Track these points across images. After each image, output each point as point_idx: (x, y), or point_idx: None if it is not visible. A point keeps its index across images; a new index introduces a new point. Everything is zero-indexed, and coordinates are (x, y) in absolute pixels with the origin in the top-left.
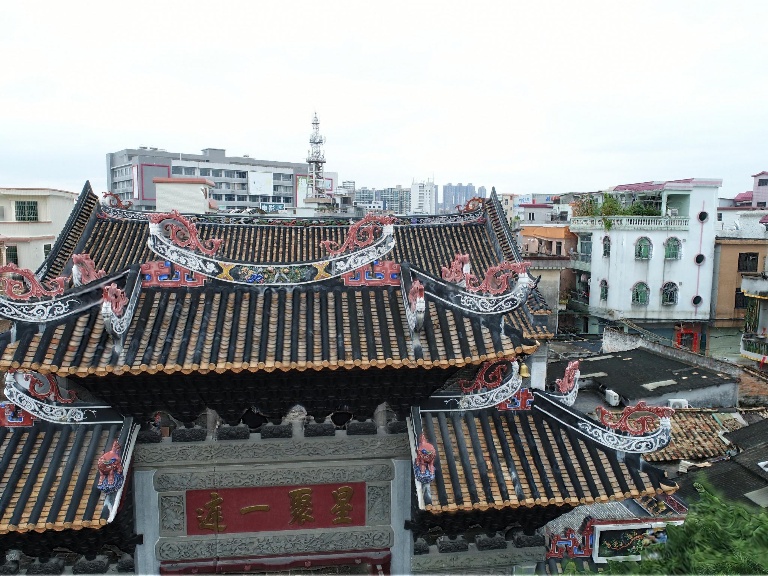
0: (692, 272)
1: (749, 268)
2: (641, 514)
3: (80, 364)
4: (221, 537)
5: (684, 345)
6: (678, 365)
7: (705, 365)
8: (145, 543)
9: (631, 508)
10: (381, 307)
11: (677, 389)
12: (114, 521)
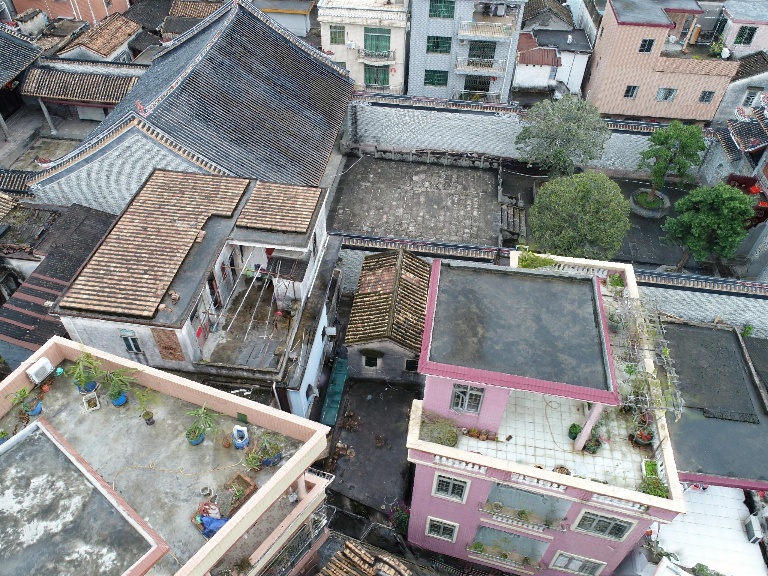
0: None
1: None
2: None
3: (760, 119)
4: (764, 176)
5: None
6: None
7: None
8: (757, 167)
9: None
10: None
11: None
12: (752, 155)
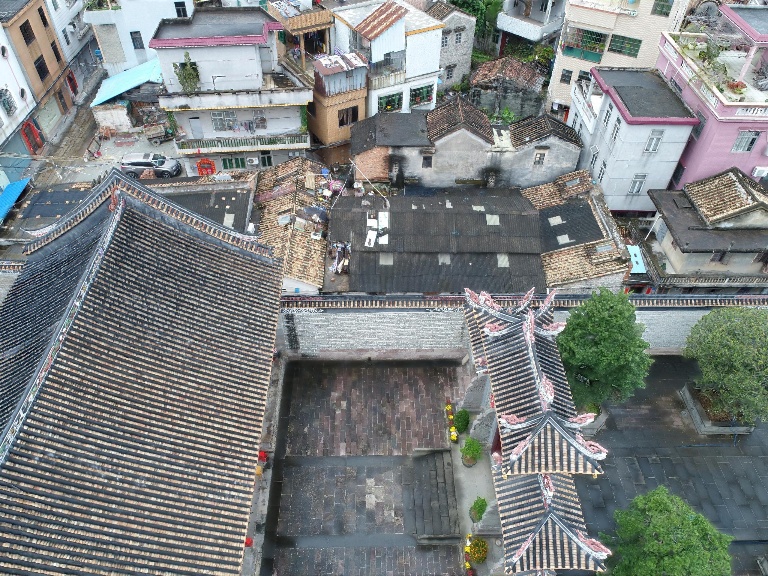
0: (6, 68)
1: (30, 38)
2: (419, 310)
3: None
4: None
5: (29, 138)
6: (202, 197)
7: (221, 188)
8: None
9: (411, 311)
10: (537, 339)
11: (243, 220)
12: None
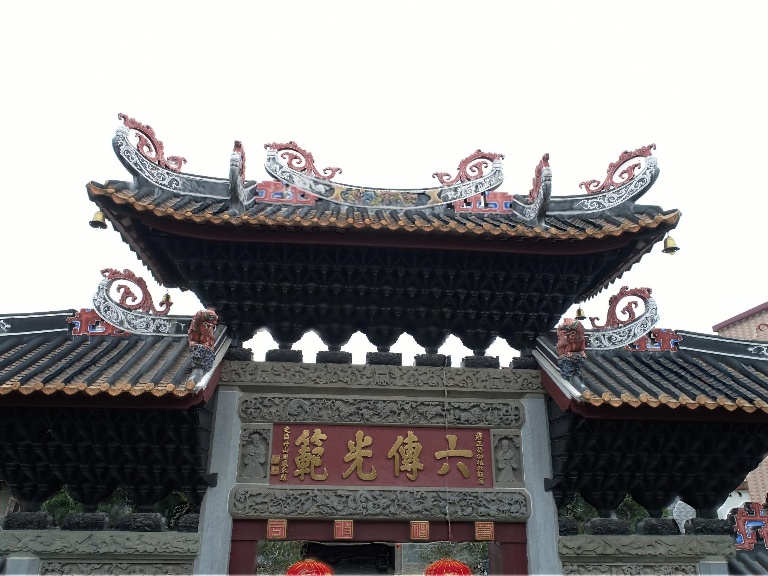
0: None
1: None
2: None
3: None
4: None
5: None
6: None
7: None
8: None
9: None
10: None
11: None
12: None
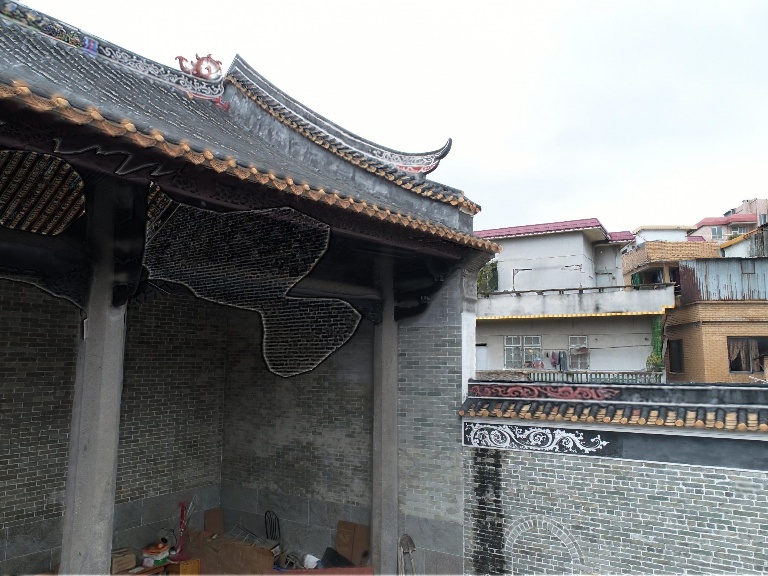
0: None
1: None
2: None
3: None
4: None
5: None
6: None
7: None
8: None
9: None
10: None
11: None
12: None
